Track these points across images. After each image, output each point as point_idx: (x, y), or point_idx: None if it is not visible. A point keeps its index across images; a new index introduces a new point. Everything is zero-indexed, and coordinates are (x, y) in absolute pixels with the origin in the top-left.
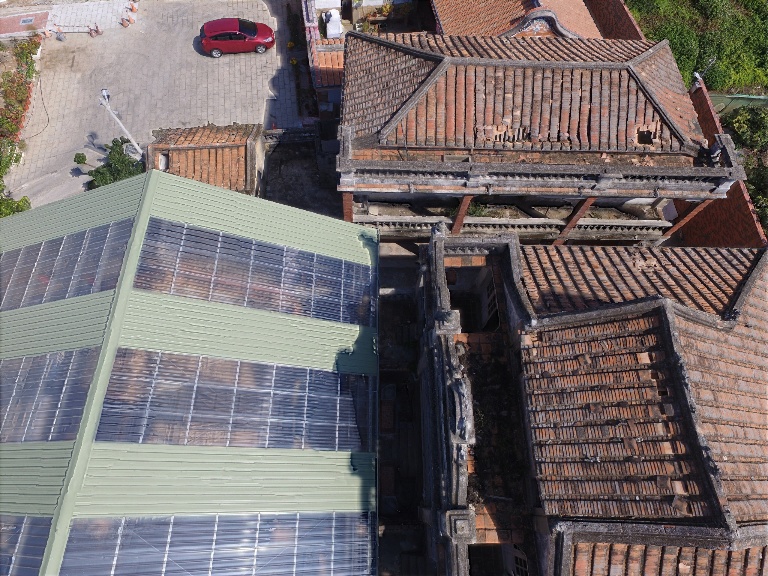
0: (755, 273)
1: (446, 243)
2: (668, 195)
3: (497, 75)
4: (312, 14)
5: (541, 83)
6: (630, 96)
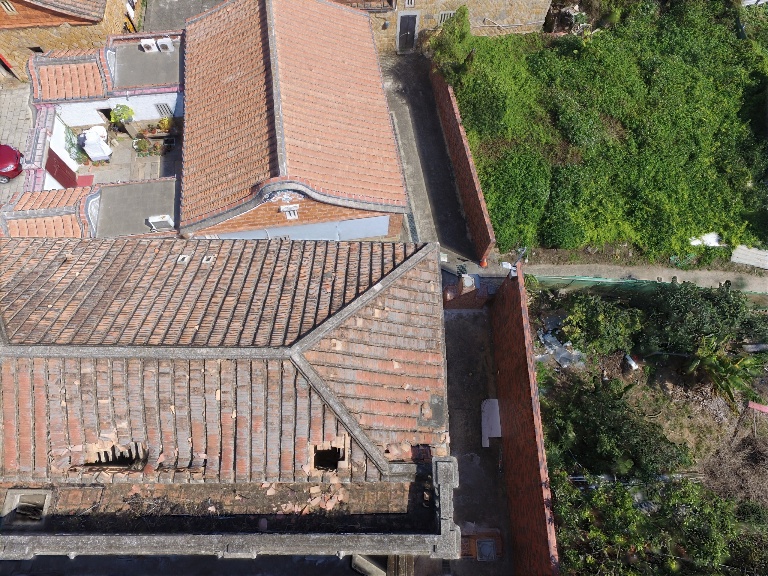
0: None
1: None
2: (360, 551)
3: (83, 371)
4: (34, 151)
5: (156, 381)
6: (298, 399)
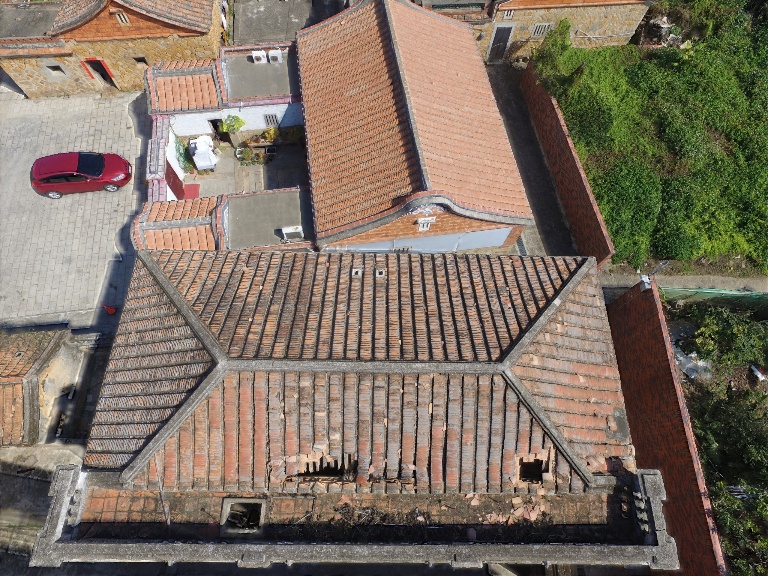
0: None
1: None
2: None
3: (302, 385)
4: (157, 161)
5: (371, 394)
6: (507, 413)
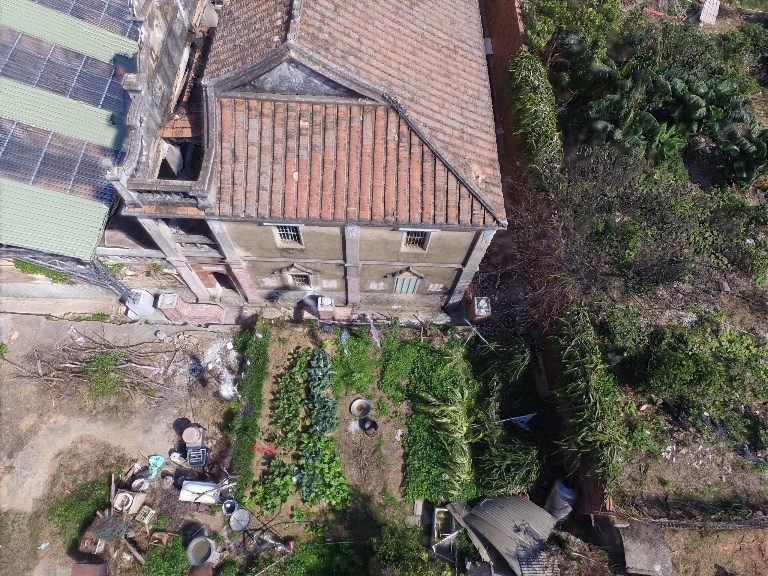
0: None
1: None
2: None
3: None
4: None
5: None
6: None
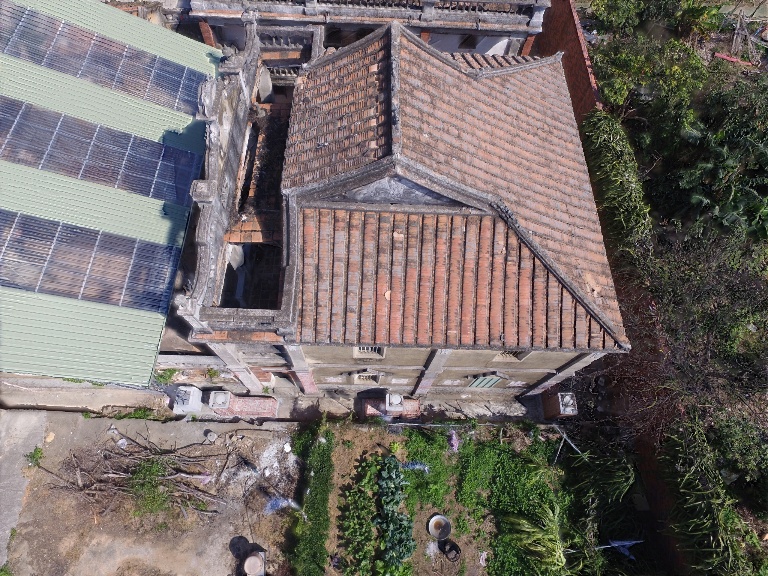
0: (531, 62)
1: (258, 29)
2: (489, 28)
3: None
4: None
5: None
6: None
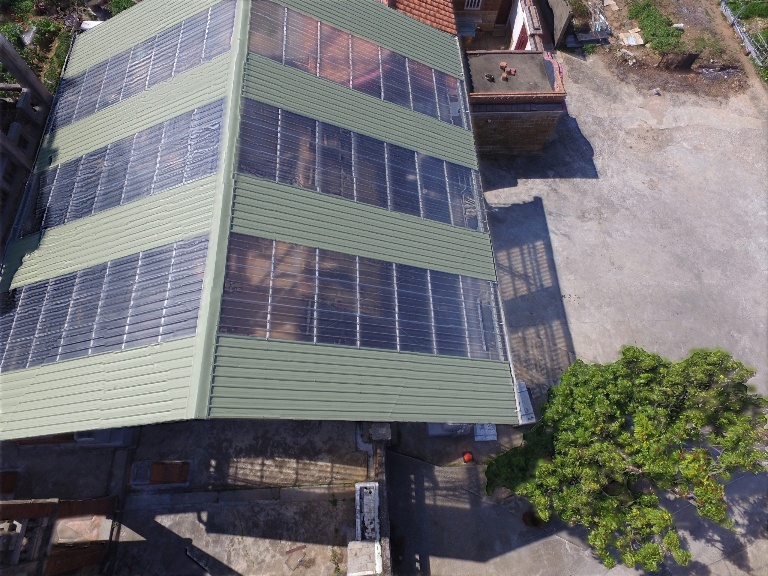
0: None
1: None
2: None
3: None
4: None
5: None
6: None
